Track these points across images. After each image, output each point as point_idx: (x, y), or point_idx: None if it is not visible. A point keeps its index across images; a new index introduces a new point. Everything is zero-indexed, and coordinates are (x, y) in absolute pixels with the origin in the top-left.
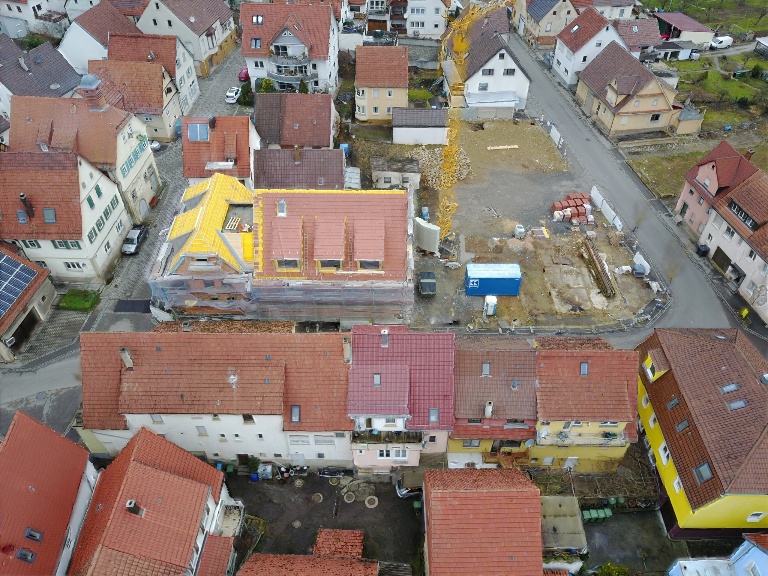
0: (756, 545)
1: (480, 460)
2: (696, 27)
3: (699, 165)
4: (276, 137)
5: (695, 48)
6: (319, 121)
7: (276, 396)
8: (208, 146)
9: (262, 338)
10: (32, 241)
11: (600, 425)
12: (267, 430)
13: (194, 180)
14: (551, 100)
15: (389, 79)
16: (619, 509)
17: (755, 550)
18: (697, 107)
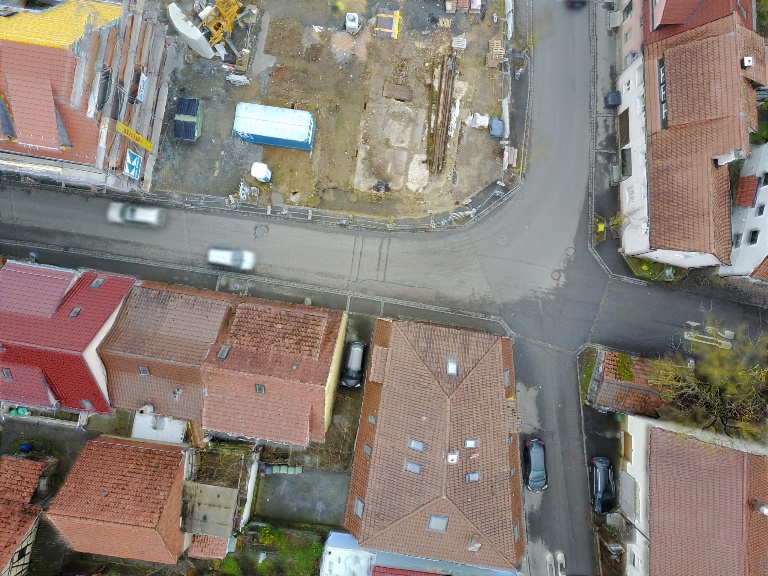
0: None
1: None
2: None
3: None
4: None
5: None
6: None
7: None
8: None
9: None
10: None
11: None
12: None
13: None
14: None
15: None
16: None
17: None
18: None
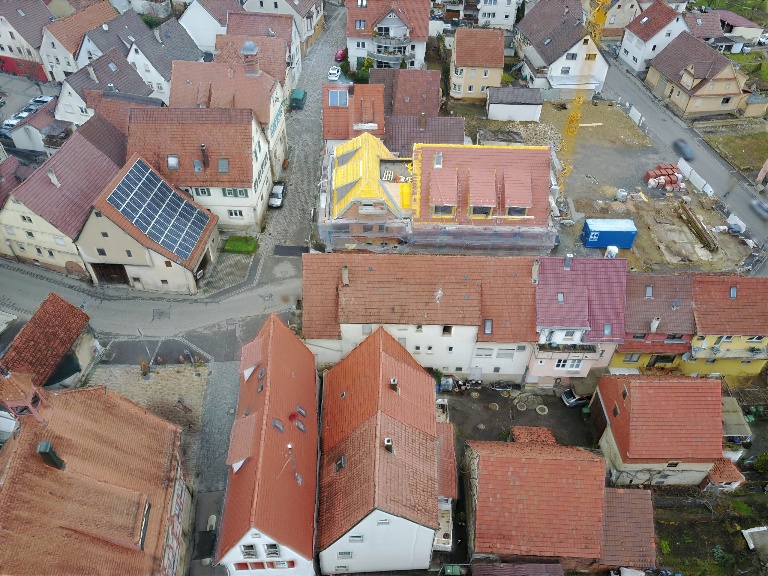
0: None
1: (638, 373)
2: (746, 23)
3: None
4: (388, 109)
5: (747, 42)
6: (429, 95)
7: (475, 310)
8: (346, 111)
9: (461, 260)
10: (204, 189)
11: (747, 341)
12: (459, 343)
13: (332, 142)
14: (623, 85)
15: (486, 59)
16: (757, 417)
17: None
18: (764, 92)
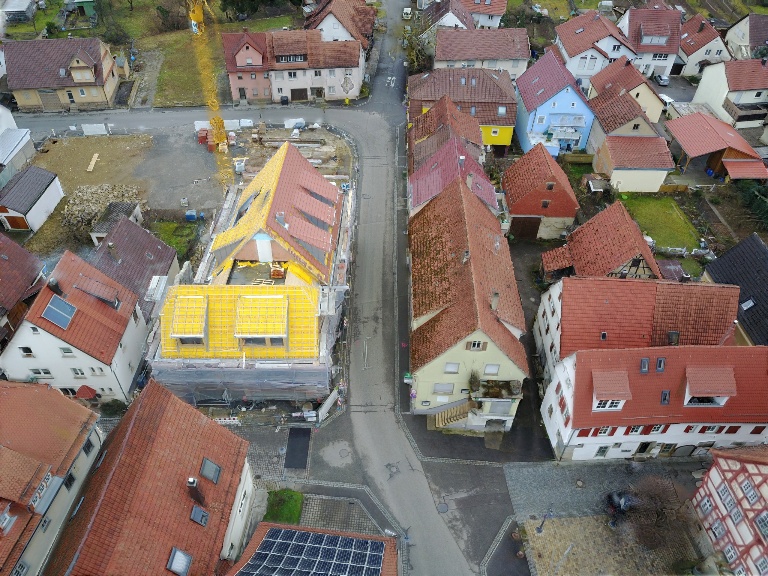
0: (538, 107)
1: None
2: None
3: (235, 55)
4: None
5: None
6: (7, 252)
7: (498, 236)
8: (82, 314)
9: None
10: None
11: None
12: None
13: (114, 359)
14: None
15: None
16: None
17: (539, 109)
18: None
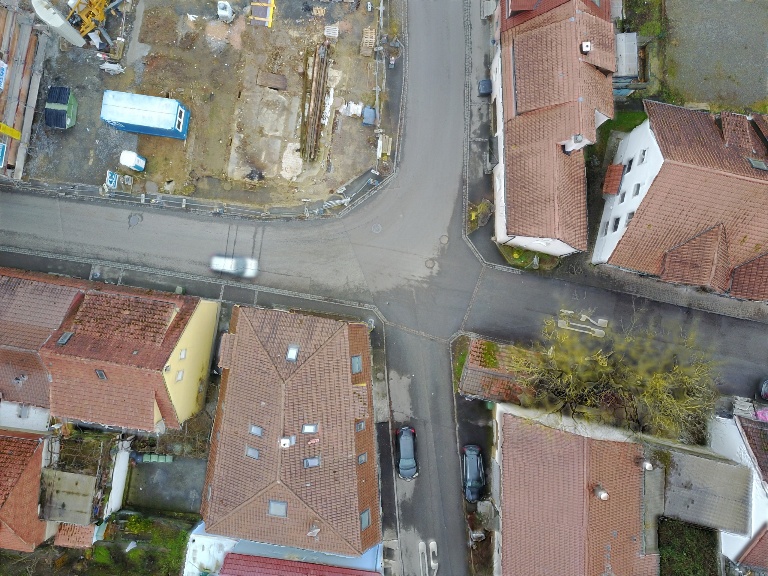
0: None
1: None
2: None
3: None
4: None
5: None
6: None
7: None
8: None
9: None
10: None
11: None
12: None
13: None
14: None
15: None
16: None
17: None
18: None
